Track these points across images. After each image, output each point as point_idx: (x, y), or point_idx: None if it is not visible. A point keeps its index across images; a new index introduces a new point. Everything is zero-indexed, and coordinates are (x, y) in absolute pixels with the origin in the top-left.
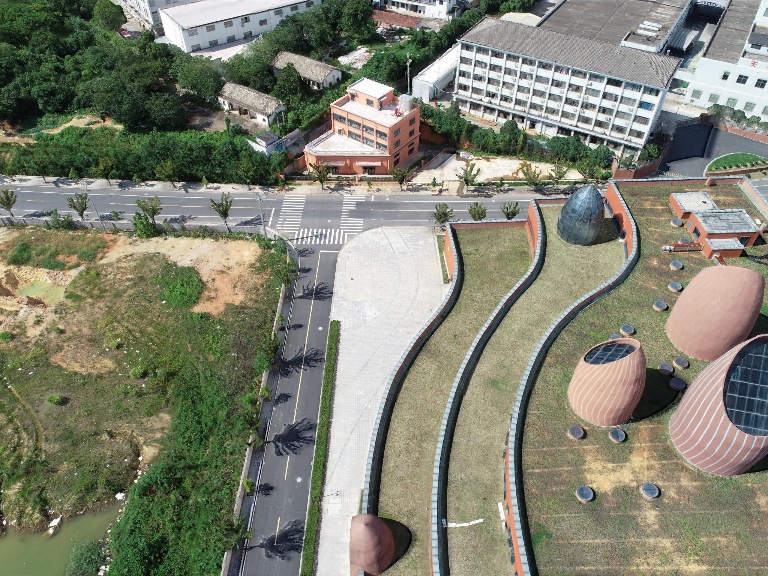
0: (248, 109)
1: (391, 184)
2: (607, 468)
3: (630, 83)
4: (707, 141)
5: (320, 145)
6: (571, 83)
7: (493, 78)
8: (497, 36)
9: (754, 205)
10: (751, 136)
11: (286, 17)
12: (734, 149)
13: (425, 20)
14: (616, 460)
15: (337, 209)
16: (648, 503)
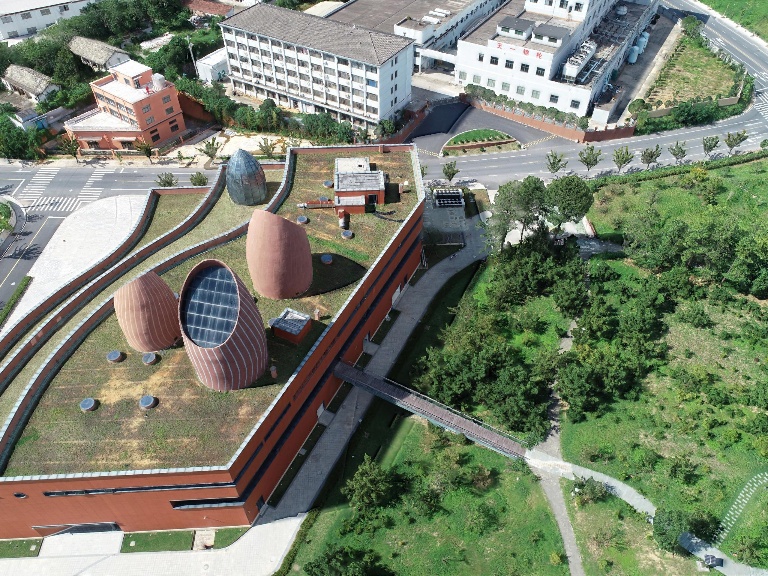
0: (22, 89)
1: (145, 158)
2: (124, 385)
3: (354, 61)
4: (457, 118)
5: (82, 122)
6: (312, 63)
7: (255, 59)
8: (252, 19)
9: (412, 169)
10: (501, 114)
11: (88, 4)
12: (479, 125)
13: (243, 8)
14: (136, 379)
15: (83, 180)
16: (141, 412)
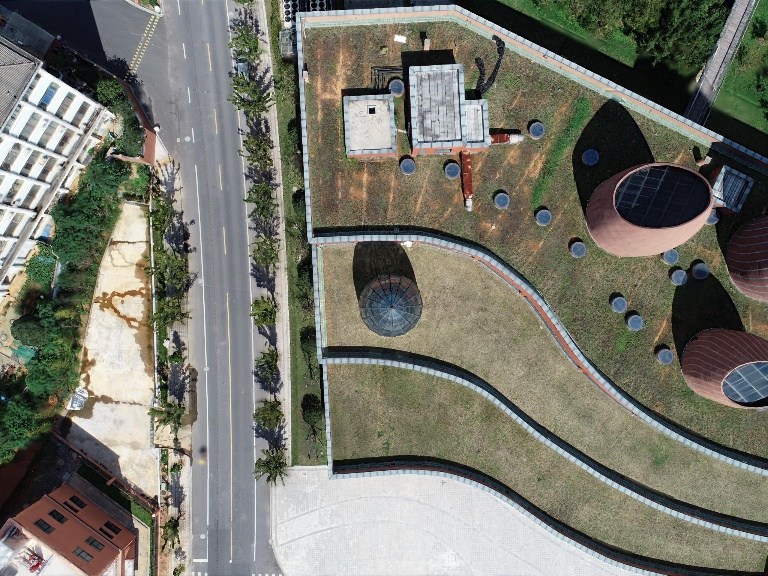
0: None
1: None
2: None
3: None
4: None
5: None
6: None
7: None
8: None
9: (359, 26)
10: None
11: None
12: None
13: None
14: None
15: None
16: None
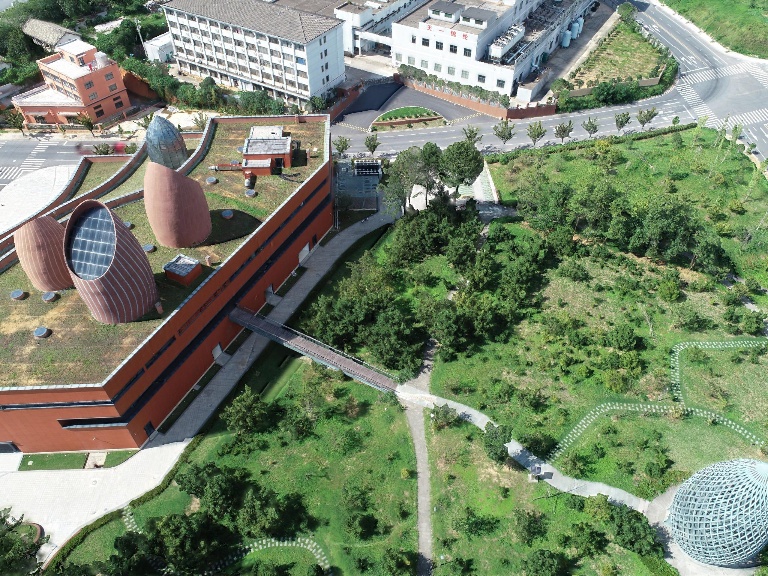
0: None
1: (89, 132)
2: (23, 319)
3: (283, 40)
4: (389, 97)
5: (29, 98)
6: (247, 42)
7: (196, 40)
8: (192, 1)
9: (324, 137)
10: (432, 93)
11: None
12: (409, 103)
13: None
14: (35, 314)
15: (27, 151)
16: (34, 341)
